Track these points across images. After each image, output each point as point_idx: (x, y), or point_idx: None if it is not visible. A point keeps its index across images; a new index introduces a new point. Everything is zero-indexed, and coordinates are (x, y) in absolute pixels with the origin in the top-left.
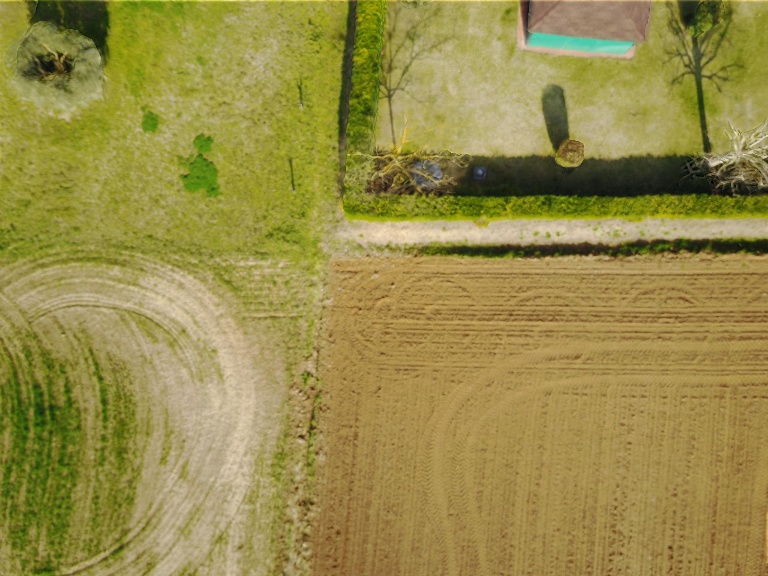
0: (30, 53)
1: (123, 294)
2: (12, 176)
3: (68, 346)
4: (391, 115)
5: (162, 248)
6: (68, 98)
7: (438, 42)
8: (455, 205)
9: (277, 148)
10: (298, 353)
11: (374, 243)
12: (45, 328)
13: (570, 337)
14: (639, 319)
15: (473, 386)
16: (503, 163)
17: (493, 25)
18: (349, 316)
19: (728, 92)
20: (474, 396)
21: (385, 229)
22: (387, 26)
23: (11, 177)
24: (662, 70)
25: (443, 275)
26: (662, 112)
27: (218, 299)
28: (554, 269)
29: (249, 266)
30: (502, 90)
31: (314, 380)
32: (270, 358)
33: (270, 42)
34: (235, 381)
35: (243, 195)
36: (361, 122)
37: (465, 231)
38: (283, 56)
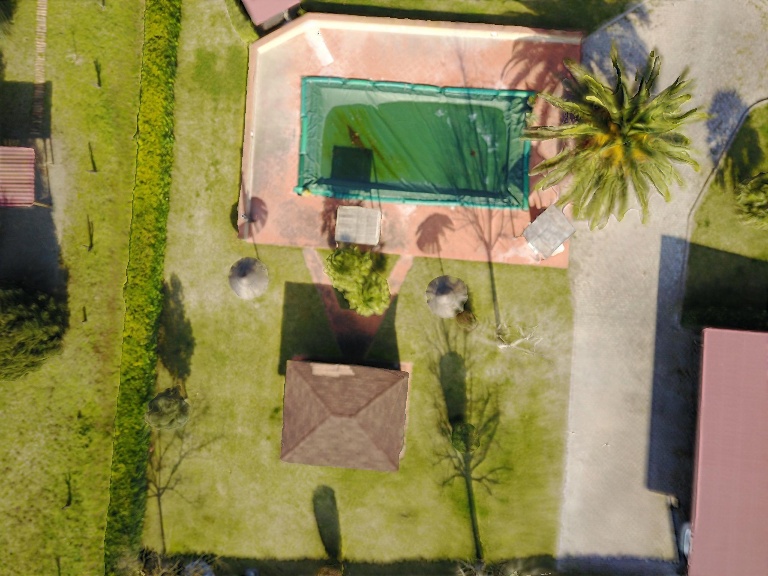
0: None
1: None
2: None
3: None
4: (161, 514)
5: None
6: None
7: (207, 441)
8: None
9: (43, 547)
10: None
11: None
12: None
13: None
14: None
15: None
16: (275, 566)
17: (263, 424)
18: None
19: (499, 495)
20: None
21: None
22: None
23: None
24: (433, 471)
25: None
26: (434, 515)
27: None
28: None
29: None
30: (273, 490)
31: None
32: None
33: (38, 436)
34: None
35: None
36: (119, 540)
37: None
38: (51, 450)
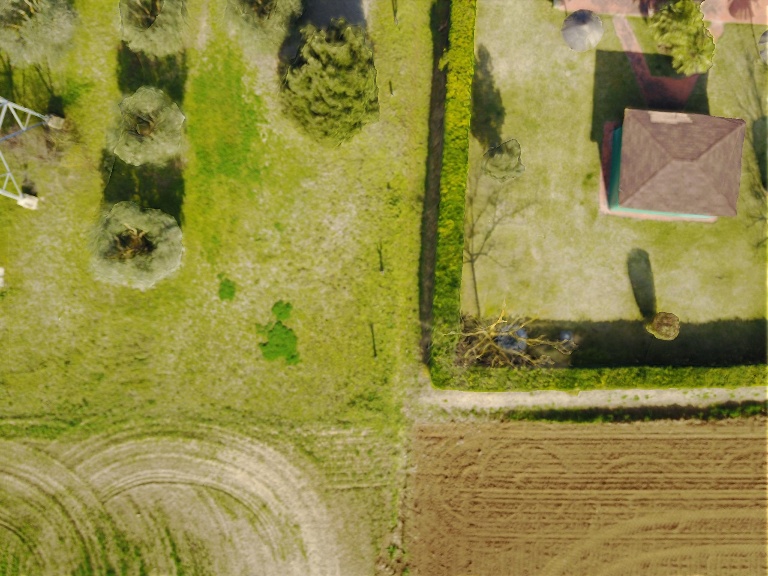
0: (111, 233)
1: (200, 469)
2: (84, 349)
3: (143, 527)
4: (474, 280)
5: (241, 419)
6: (149, 277)
7: (521, 207)
8: (548, 378)
9: (358, 313)
10: (383, 525)
11: (458, 408)
12: (119, 508)
13: (666, 505)
14: (735, 485)
15: (568, 559)
16: (590, 327)
17: (576, 190)
18: (435, 484)
19: None
20: (569, 569)
21: (470, 394)
22: (468, 191)
23: (83, 350)
24: (747, 233)
25: (531, 441)
26: (749, 275)
27: (299, 471)
28: (645, 434)
29: (331, 436)
30: (587, 254)
31: (400, 552)
32: (354, 531)
33: (349, 207)
34: (319, 557)
35: (323, 362)
36: (449, 294)
37: (552, 395)
38: (362, 221)
